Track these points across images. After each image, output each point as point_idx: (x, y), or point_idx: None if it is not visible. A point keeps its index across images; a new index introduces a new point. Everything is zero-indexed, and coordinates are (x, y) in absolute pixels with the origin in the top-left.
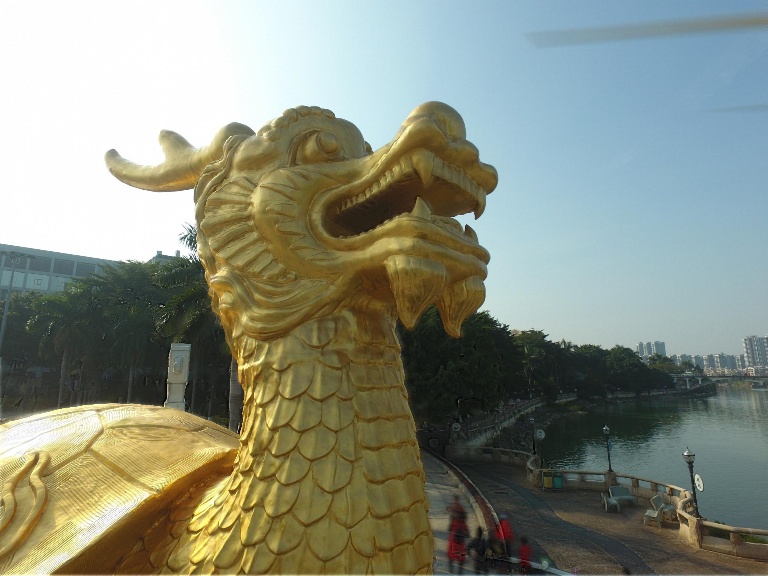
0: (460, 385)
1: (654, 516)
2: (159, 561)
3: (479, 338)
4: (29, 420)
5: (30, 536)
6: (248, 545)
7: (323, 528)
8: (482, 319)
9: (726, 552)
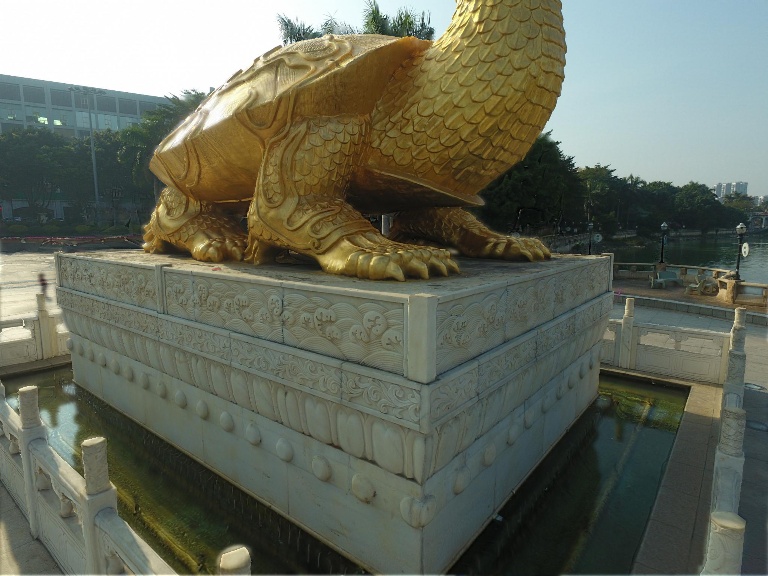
0: (523, 195)
1: (696, 286)
2: (420, 62)
3: (544, 153)
4: None
5: (354, 51)
6: (480, 21)
7: (519, 8)
8: (548, 136)
9: (756, 304)
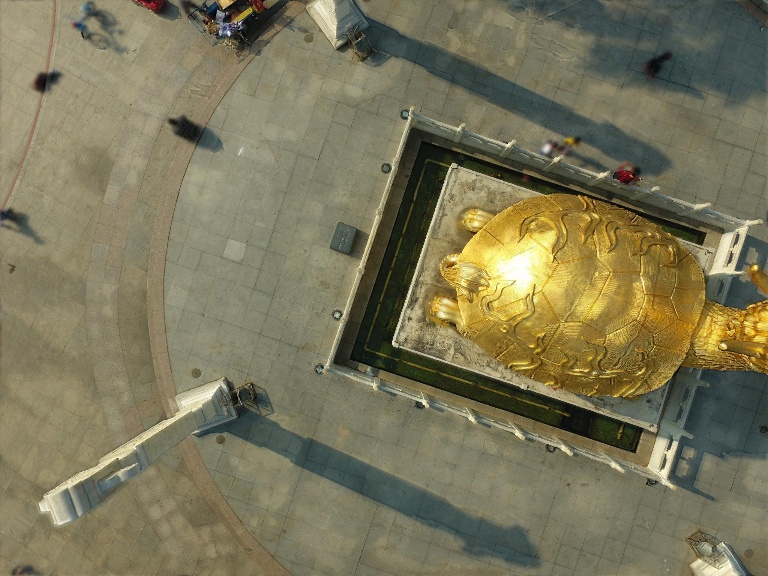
0: None
1: None
2: None
3: None
4: (612, 331)
5: (655, 367)
6: None
7: None
8: None
9: None
